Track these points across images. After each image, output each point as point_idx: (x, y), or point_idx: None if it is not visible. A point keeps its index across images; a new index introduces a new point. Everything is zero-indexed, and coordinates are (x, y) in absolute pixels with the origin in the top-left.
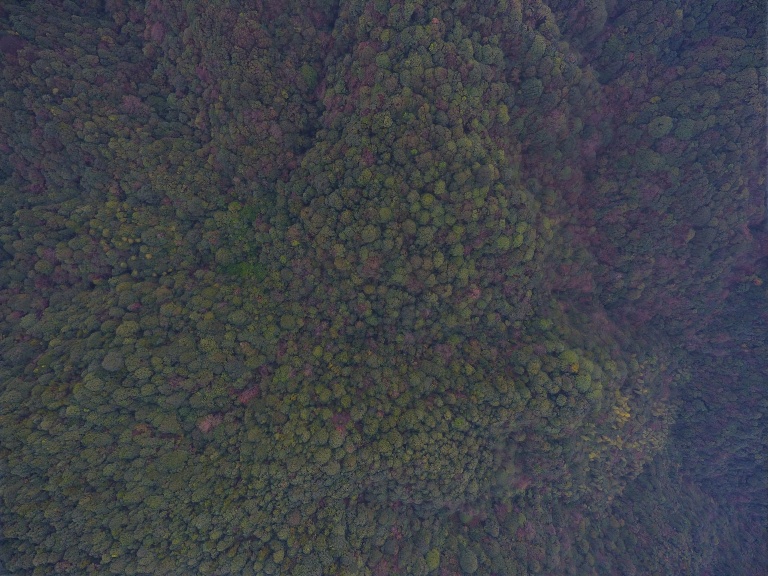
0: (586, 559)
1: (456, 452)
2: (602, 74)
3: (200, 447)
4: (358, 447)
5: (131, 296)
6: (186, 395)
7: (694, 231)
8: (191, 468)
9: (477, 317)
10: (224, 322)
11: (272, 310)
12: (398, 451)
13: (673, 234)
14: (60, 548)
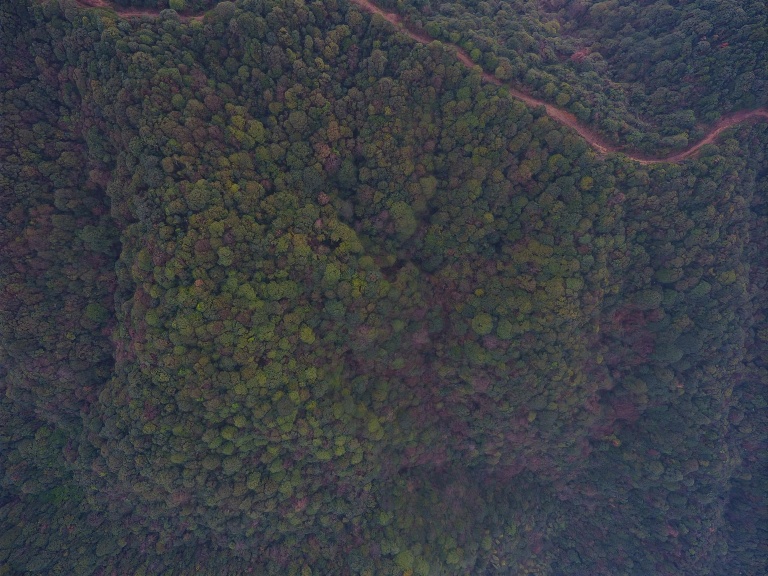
0: None
1: None
2: (427, 265)
3: None
4: None
5: None
6: None
7: (534, 414)
8: None
9: (309, 521)
10: (23, 571)
11: (86, 538)
12: None
13: (517, 413)
14: None
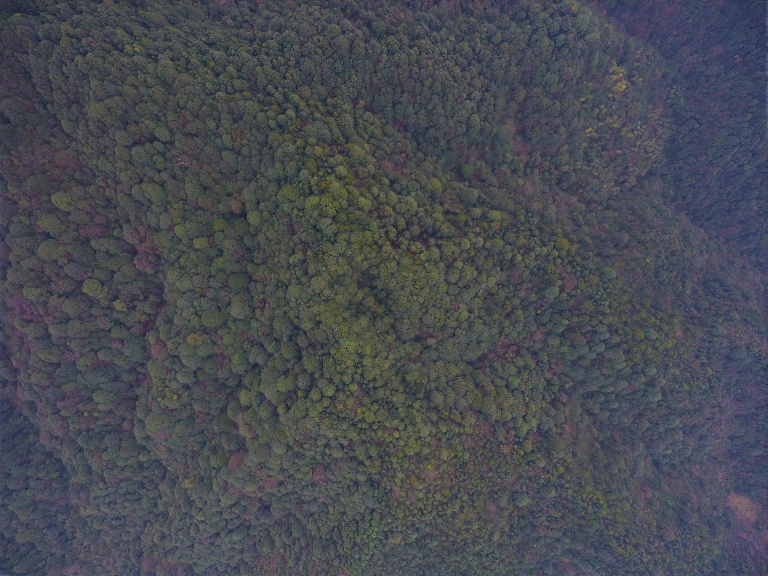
0: (581, 228)
1: None
2: None
3: (216, 19)
4: (367, 40)
5: None
6: None
7: None
8: None
9: None
10: None
11: None
12: (405, 47)
13: None
14: (86, 26)
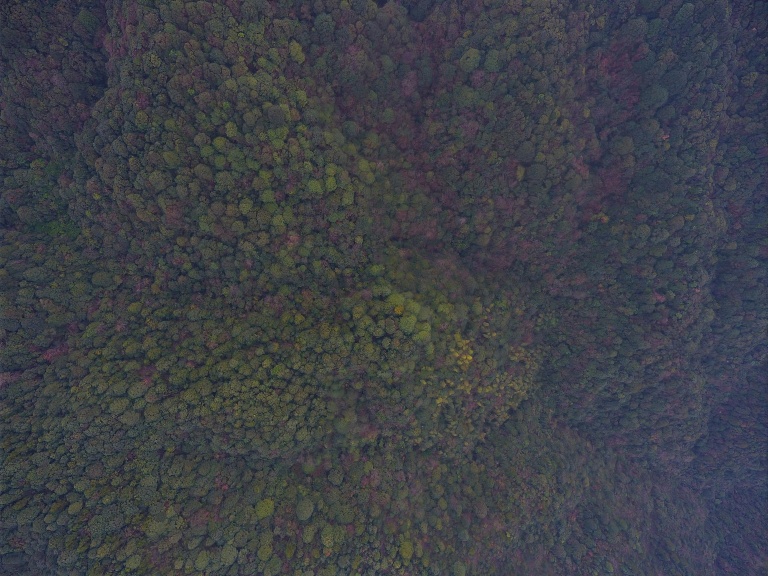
0: (438, 503)
1: (275, 399)
2: (415, 11)
3: None
4: (163, 397)
5: None
6: None
7: (523, 168)
8: None
9: (302, 265)
10: (20, 279)
11: (82, 267)
12: (205, 399)
13: (505, 173)
14: None
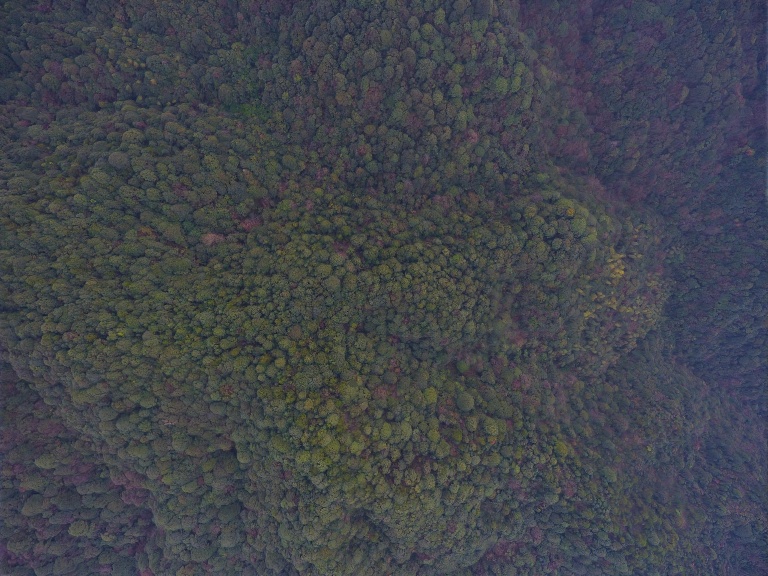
0: (580, 414)
1: (454, 286)
2: None
3: (203, 261)
4: (358, 269)
5: (136, 115)
6: (190, 209)
7: (688, 89)
8: (195, 275)
9: (475, 165)
10: (227, 147)
11: (274, 148)
12: (397, 275)
13: (668, 94)
14: (68, 319)
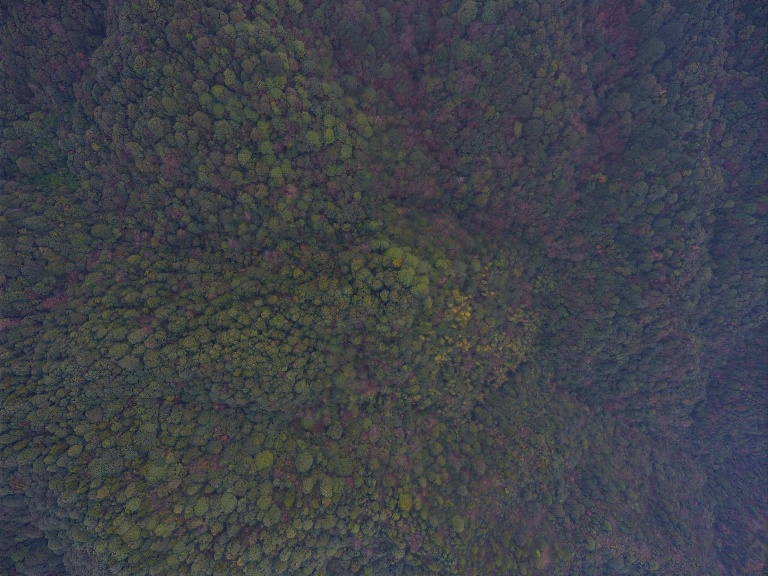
0: (437, 460)
1: (274, 349)
2: None
3: None
4: (162, 344)
5: None
6: None
7: (520, 124)
8: None
9: (300, 219)
10: (19, 227)
11: (82, 219)
12: (204, 346)
13: (503, 130)
14: None
